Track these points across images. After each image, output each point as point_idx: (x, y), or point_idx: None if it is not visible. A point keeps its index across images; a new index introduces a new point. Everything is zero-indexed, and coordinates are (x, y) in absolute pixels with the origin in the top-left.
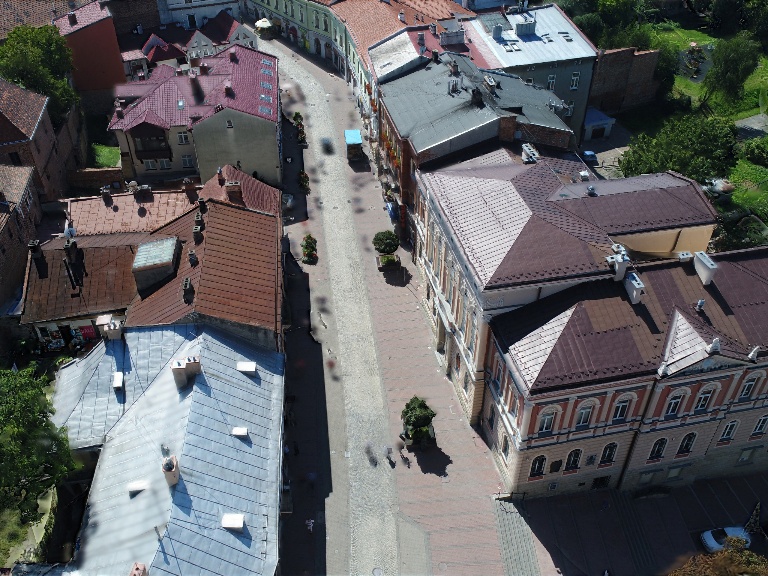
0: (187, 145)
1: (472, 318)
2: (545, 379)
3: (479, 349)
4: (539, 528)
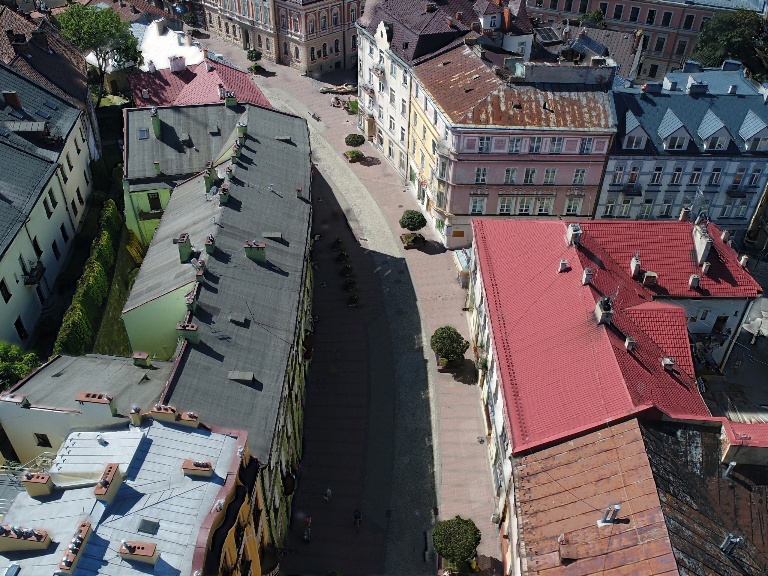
0: (28, 3)
1: (263, 4)
2: (306, 1)
3: (272, 13)
4: (322, 80)
